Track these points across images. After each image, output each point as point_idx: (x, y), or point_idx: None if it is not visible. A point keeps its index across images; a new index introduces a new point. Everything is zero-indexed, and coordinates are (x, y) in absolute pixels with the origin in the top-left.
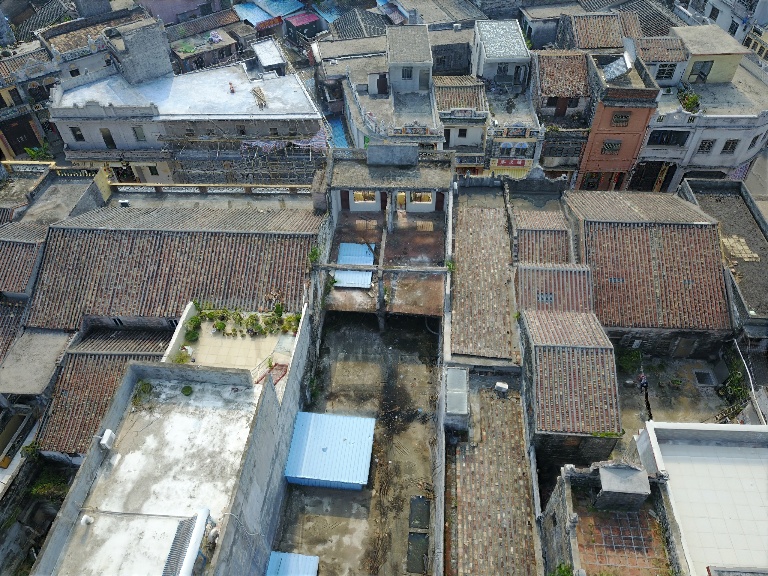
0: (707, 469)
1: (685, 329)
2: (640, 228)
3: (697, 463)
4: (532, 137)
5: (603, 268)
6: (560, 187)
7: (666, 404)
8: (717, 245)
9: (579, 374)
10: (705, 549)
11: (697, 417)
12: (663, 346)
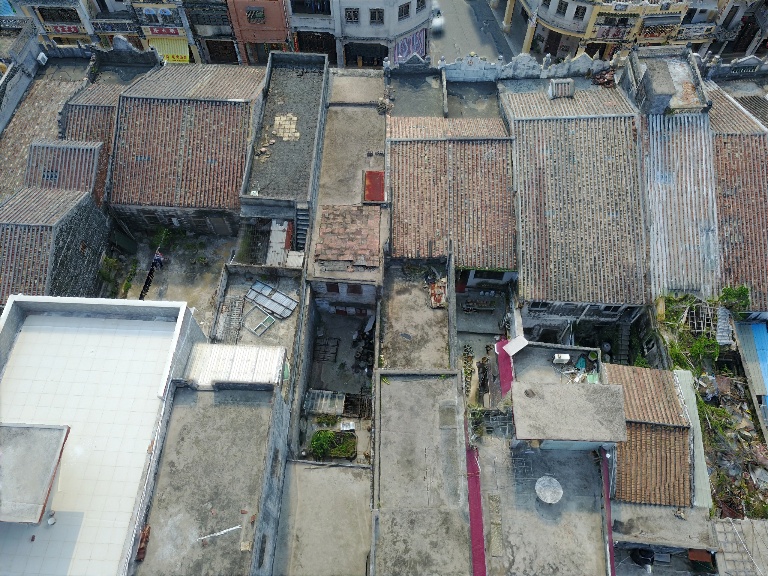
0: (61, 338)
1: (202, 208)
2: (175, 105)
3: (55, 332)
4: (170, 2)
5: (131, 146)
6: (152, 59)
7: (189, 279)
8: (246, 123)
9: (18, 250)
10: (12, 406)
11: (211, 292)
12: (202, 224)
